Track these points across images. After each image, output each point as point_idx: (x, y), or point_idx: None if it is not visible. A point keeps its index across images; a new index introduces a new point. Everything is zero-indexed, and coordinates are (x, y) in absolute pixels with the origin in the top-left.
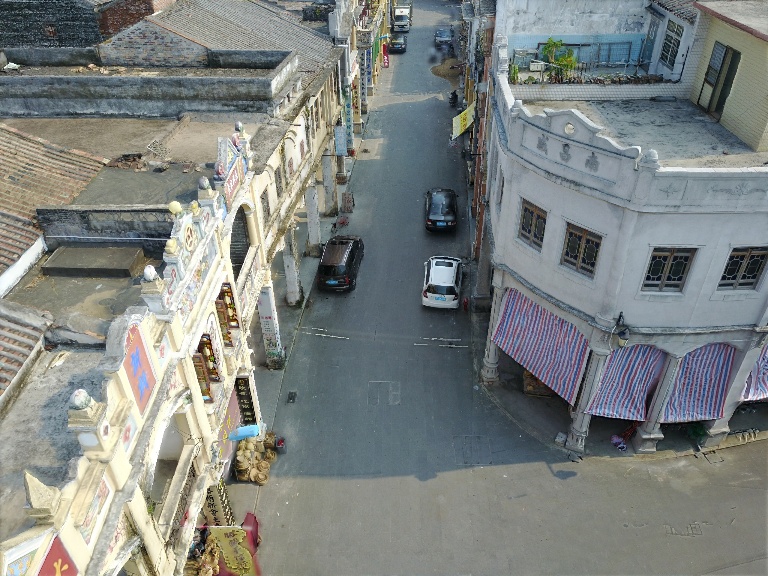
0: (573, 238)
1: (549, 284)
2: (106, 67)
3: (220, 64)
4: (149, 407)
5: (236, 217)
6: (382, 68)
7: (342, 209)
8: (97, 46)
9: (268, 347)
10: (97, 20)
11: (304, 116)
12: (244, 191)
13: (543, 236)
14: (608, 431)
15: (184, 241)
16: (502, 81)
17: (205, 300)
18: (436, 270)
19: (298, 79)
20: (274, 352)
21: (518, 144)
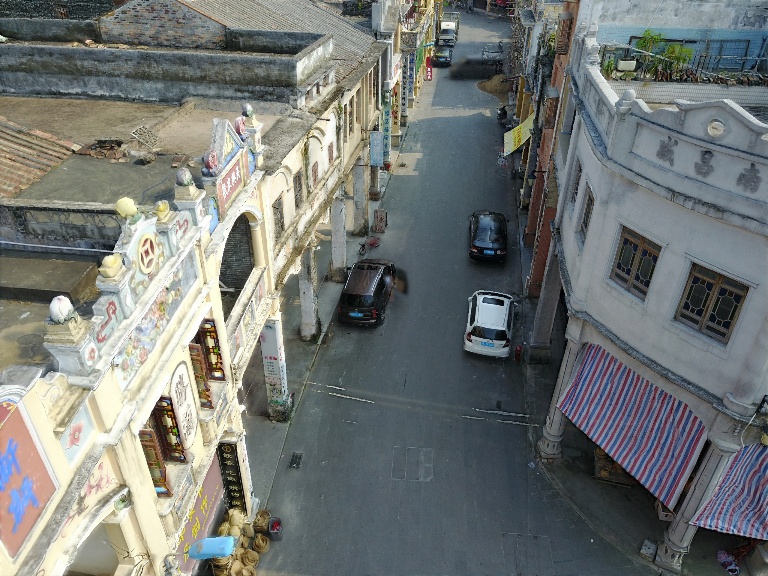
0: (699, 285)
1: (654, 345)
2: (106, 44)
3: (240, 47)
4: (33, 539)
5: (239, 229)
6: (424, 81)
7: (373, 228)
8: (98, 19)
9: (271, 394)
10: (113, 2)
11: (336, 114)
12: (247, 194)
13: (650, 279)
14: (711, 543)
15: (137, 259)
16: (594, 73)
17: (169, 346)
18: (483, 308)
19: (331, 67)
20: (278, 400)
21: (626, 150)
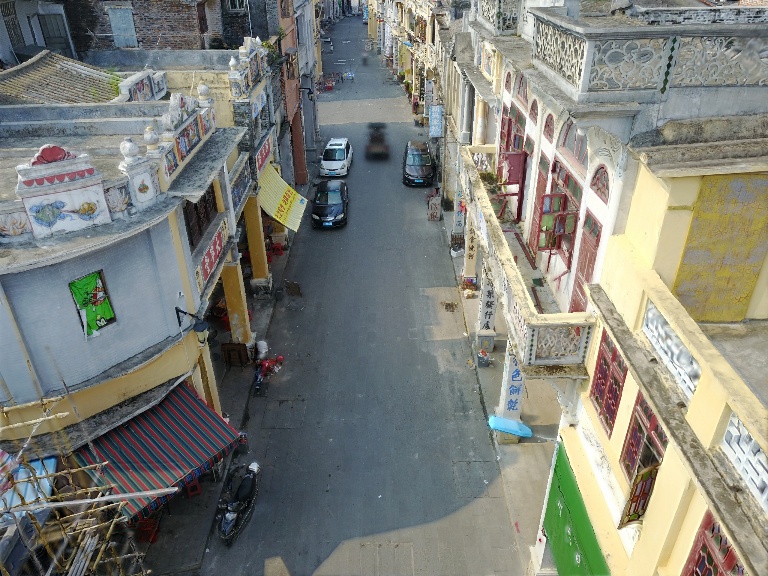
0: None
1: None
2: None
3: None
4: None
5: None
6: None
7: None
8: None
9: None
10: None
11: None
12: (431, 5)
13: None
14: None
15: None
16: None
17: None
18: None
19: (444, 5)
20: None
21: None
